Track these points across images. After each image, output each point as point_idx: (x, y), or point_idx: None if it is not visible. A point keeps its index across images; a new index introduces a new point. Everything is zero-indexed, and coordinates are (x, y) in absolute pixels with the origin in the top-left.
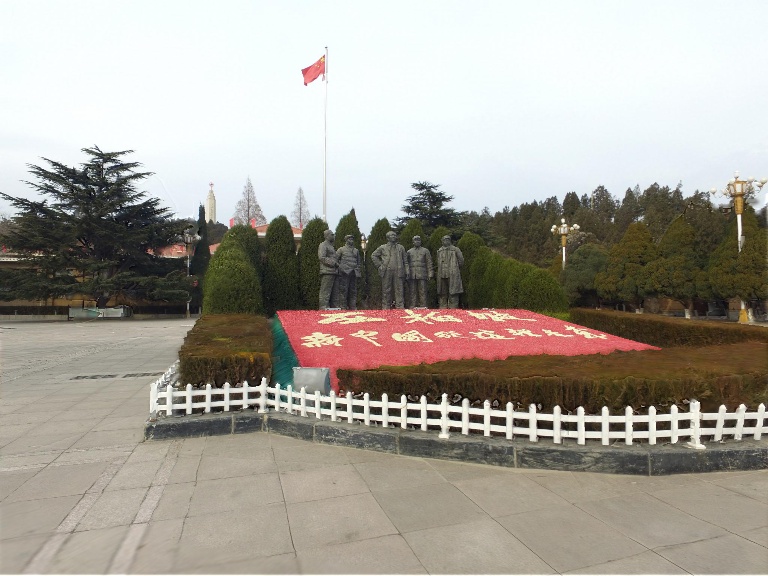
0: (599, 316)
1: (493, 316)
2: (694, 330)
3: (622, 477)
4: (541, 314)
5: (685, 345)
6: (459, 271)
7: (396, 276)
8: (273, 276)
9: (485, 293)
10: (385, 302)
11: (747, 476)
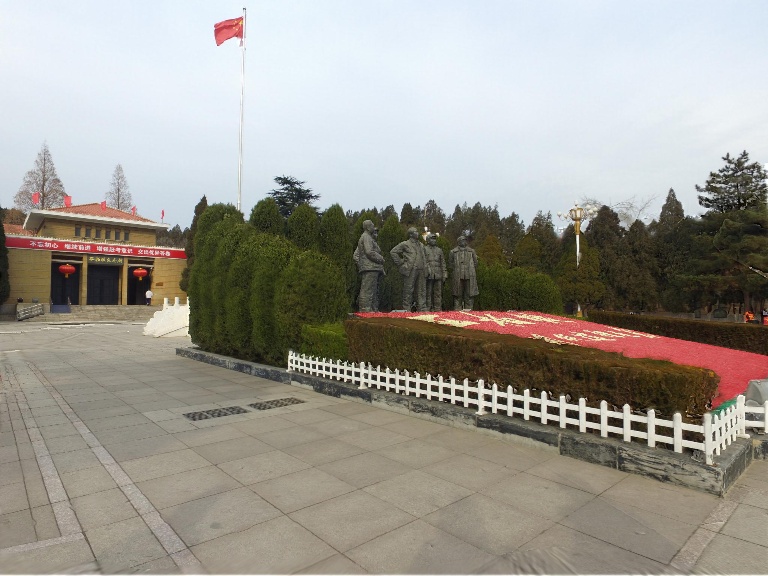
0: (626, 318)
1: (537, 318)
2: (738, 329)
3: None
4: (560, 316)
5: (726, 342)
6: None
7: (421, 276)
8: None
9: None
10: (408, 303)
11: None
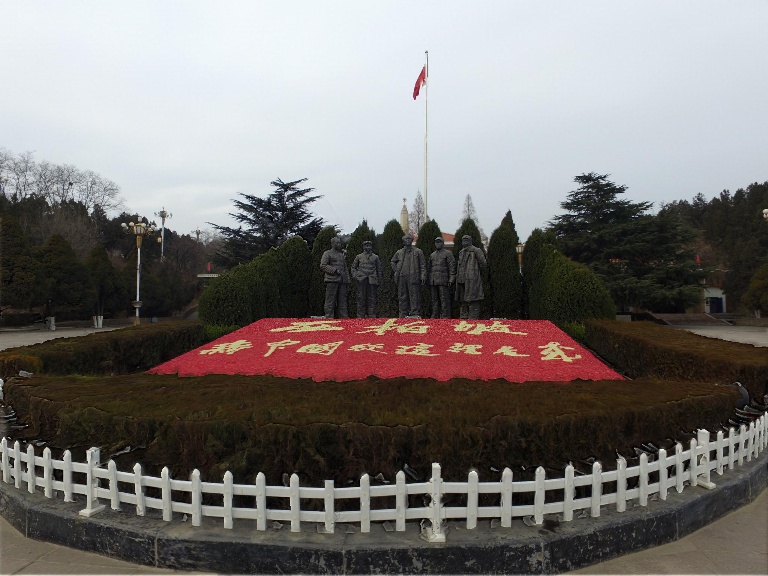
0: (602, 331)
1: (481, 328)
2: (665, 355)
3: (2, 531)
4: (556, 326)
5: (662, 377)
6: (479, 275)
7: (409, 282)
8: (315, 285)
9: (537, 300)
10: (400, 310)
11: (96, 568)
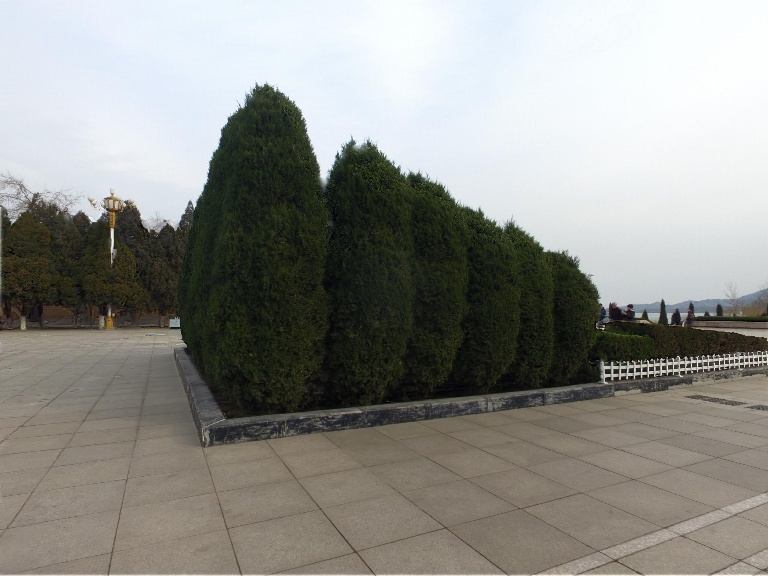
0: None
1: None
2: None
3: None
4: None
5: None
6: None
7: None
8: None
9: None
10: None
11: None
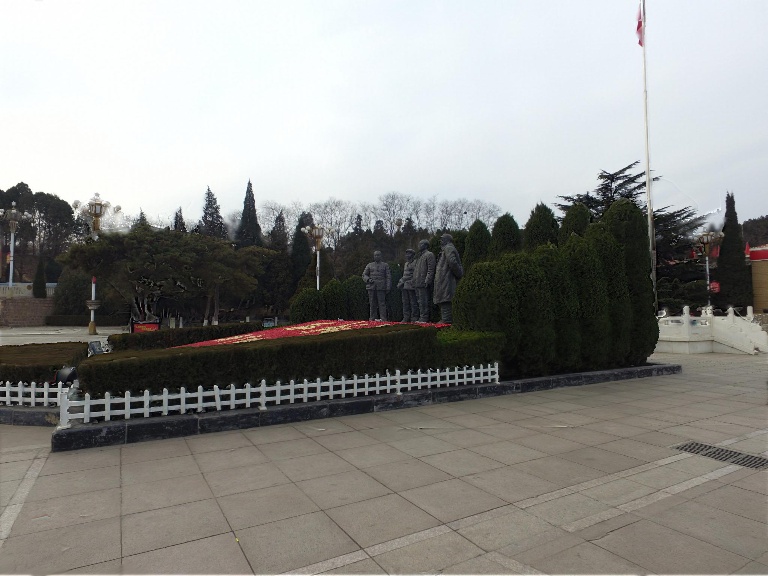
0: None
1: None
2: None
3: None
4: None
5: None
6: (447, 275)
7: None
8: None
9: None
10: None
11: None
